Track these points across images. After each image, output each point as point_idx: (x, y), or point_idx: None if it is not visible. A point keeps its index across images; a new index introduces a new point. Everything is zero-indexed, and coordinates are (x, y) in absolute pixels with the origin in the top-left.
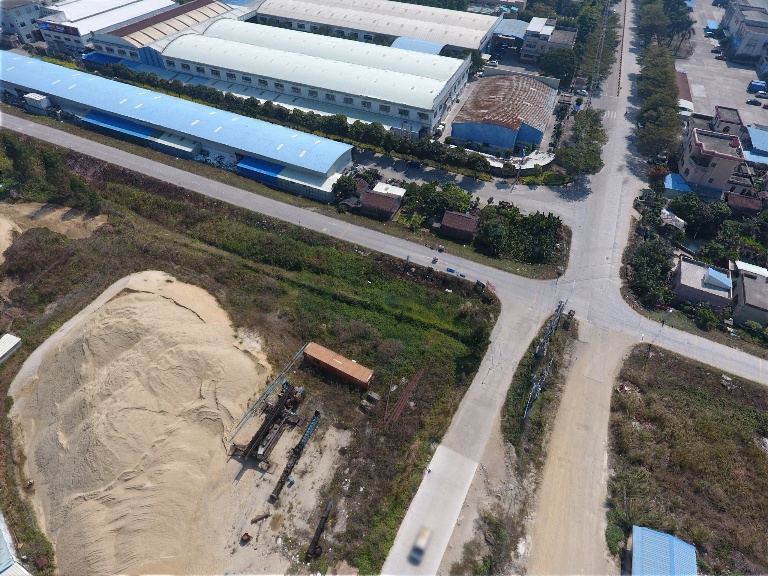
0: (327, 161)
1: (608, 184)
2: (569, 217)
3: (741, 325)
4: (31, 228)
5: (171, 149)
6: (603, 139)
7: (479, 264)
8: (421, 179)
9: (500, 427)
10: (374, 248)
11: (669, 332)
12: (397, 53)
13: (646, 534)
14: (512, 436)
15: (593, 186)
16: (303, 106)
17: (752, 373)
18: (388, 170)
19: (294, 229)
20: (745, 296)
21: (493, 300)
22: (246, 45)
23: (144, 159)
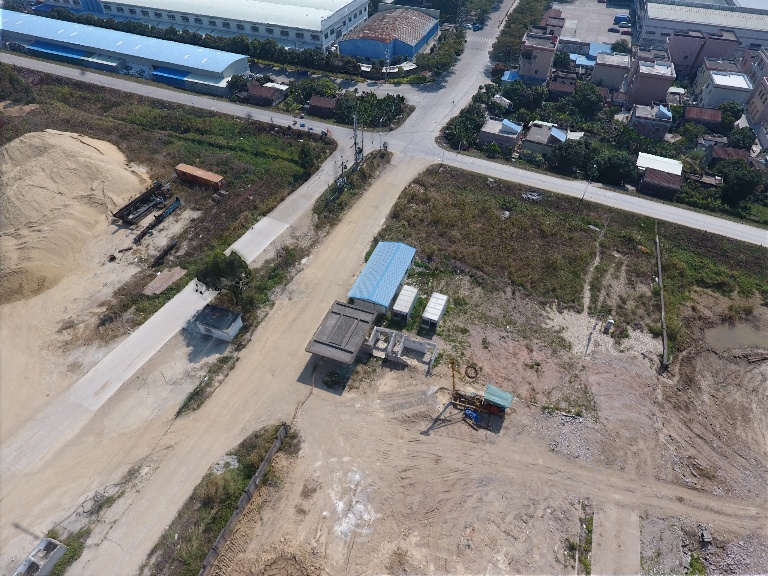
0: (223, 64)
1: (461, 83)
2: (418, 101)
3: (522, 156)
4: None
5: (100, 66)
6: (457, 47)
7: (329, 125)
8: None
9: (312, 208)
10: (249, 117)
11: (460, 158)
12: None
13: (385, 244)
14: (317, 210)
15: (448, 84)
16: None
17: (511, 177)
18: (281, 77)
19: (188, 108)
20: (526, 136)
21: (332, 143)
22: None
23: (75, 70)
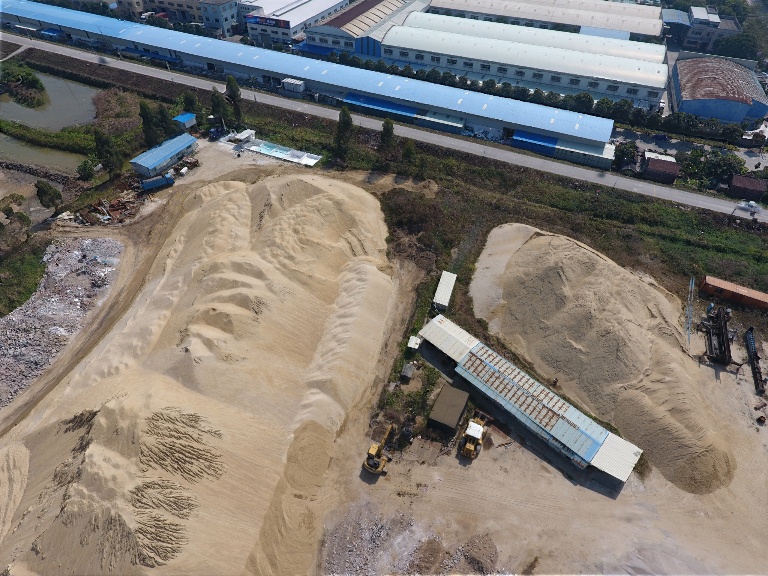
0: (604, 132)
1: None
2: None
3: None
4: (394, 188)
5: (438, 125)
6: None
7: None
8: (675, 149)
9: None
10: (691, 204)
11: None
12: (597, 39)
13: None
14: None
15: None
16: (529, 88)
17: None
18: (639, 142)
19: (609, 189)
20: None
21: None
22: (453, 34)
23: (429, 133)
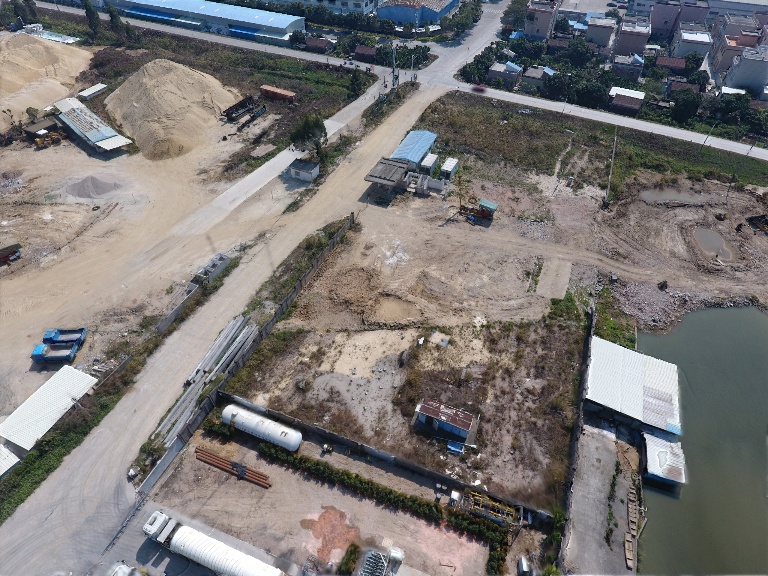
0: (286, 22)
1: (477, 41)
2: (441, 52)
3: None
4: None
5: (186, 25)
6: (474, 12)
7: None
8: None
9: (361, 115)
10: (309, 59)
11: (472, 87)
12: None
13: (415, 131)
14: (366, 115)
15: (466, 42)
16: None
17: (510, 99)
18: (330, 35)
19: (262, 53)
20: None
21: (374, 76)
22: None
23: (169, 27)
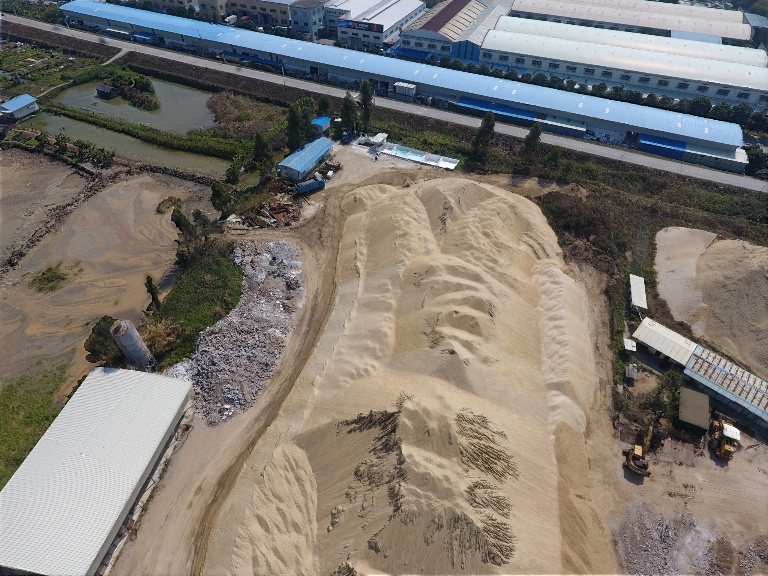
0: (735, 136)
1: None
2: None
3: None
4: (551, 192)
5: (560, 129)
6: None
7: None
8: None
9: None
10: None
11: None
12: None
13: None
14: None
15: None
16: None
17: None
18: (760, 146)
19: (756, 193)
20: None
21: None
22: (550, 38)
23: (557, 137)
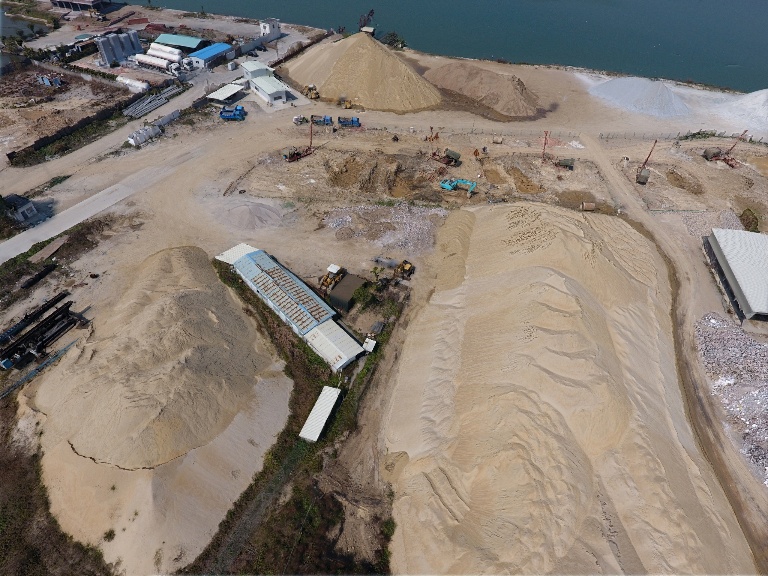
0: None
1: None
2: None
3: None
4: None
5: None
6: None
7: None
8: None
9: None
10: None
11: None
12: None
13: None
14: None
15: None
16: None
17: None
18: None
19: None
20: None
21: None
22: None
23: None
